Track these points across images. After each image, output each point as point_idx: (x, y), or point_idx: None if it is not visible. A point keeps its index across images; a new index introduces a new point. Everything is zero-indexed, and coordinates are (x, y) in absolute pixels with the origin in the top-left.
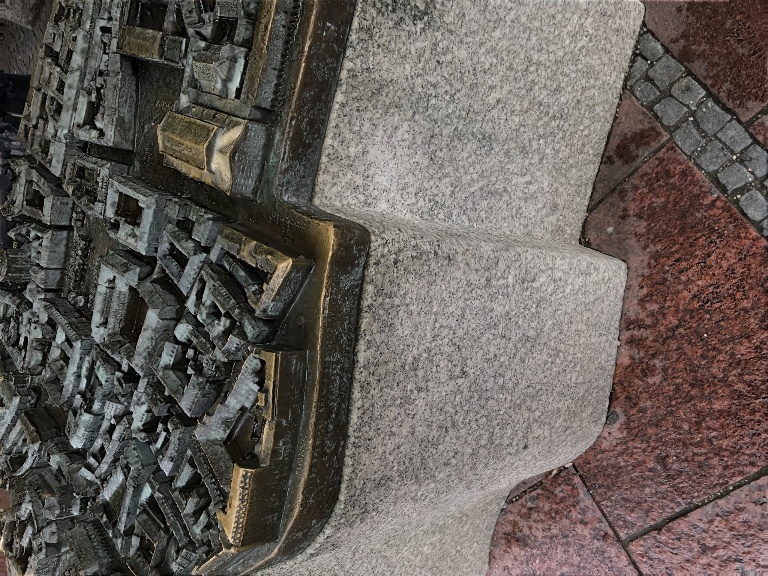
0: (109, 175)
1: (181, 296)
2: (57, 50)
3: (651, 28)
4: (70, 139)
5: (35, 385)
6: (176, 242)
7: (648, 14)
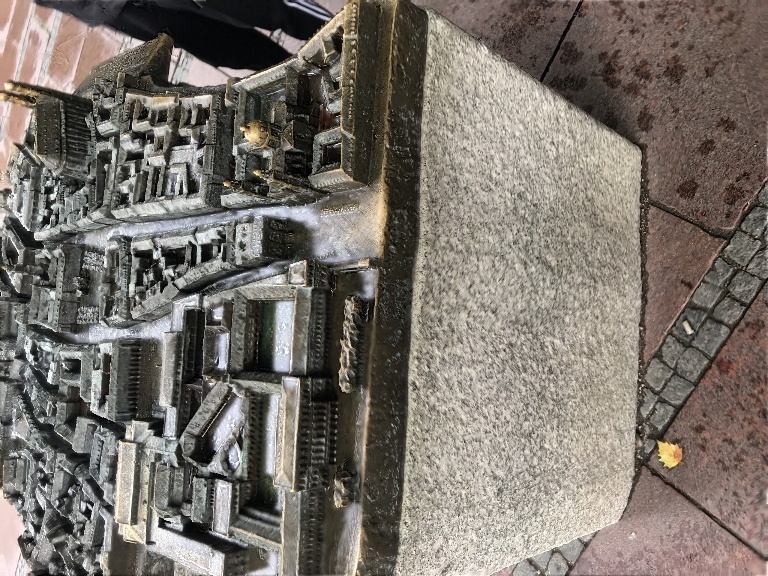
0: (121, 322)
1: None
2: (180, 133)
3: (603, 528)
4: (136, 217)
5: None
6: (101, 461)
7: (615, 523)
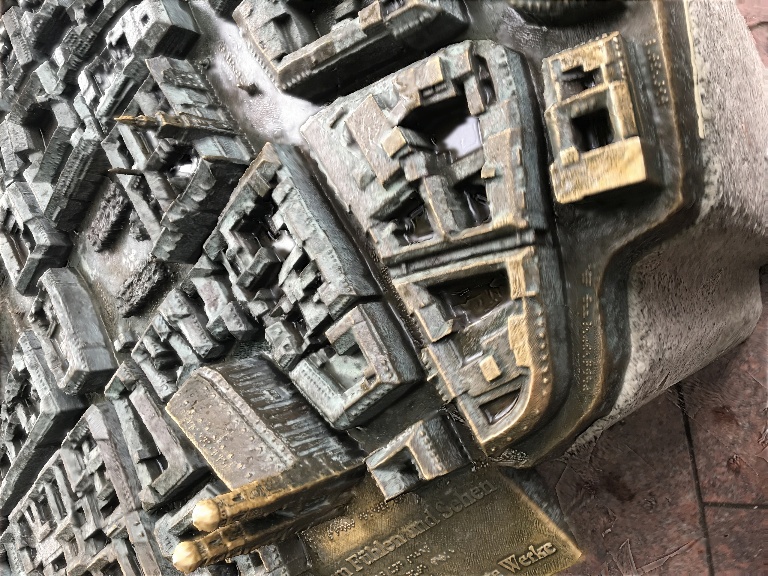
0: None
1: None
2: None
3: None
4: None
5: None
6: None
7: None
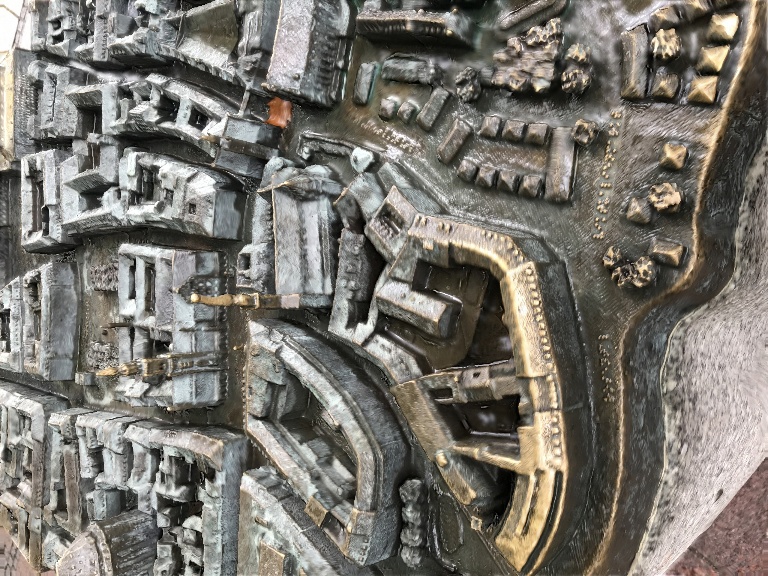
0: None
1: None
2: None
3: None
4: None
5: (179, 355)
6: (41, 100)
7: None
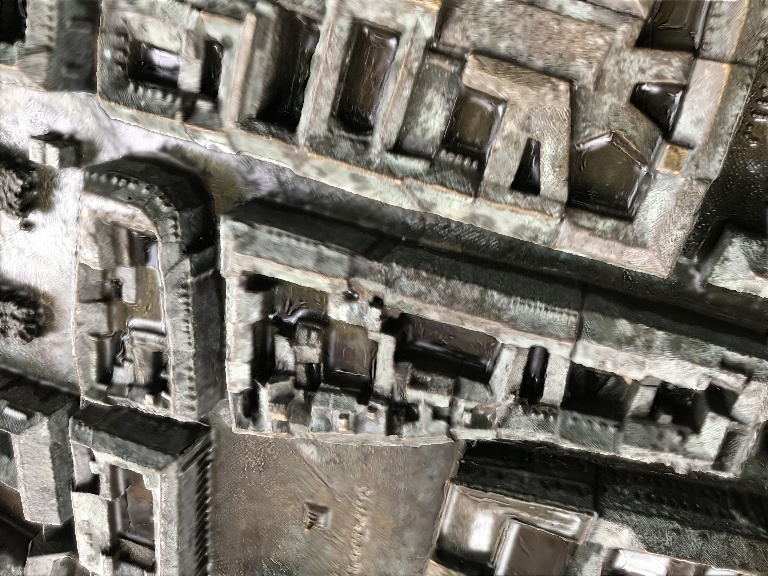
0: None
1: (77, 563)
2: None
3: None
4: None
5: None
6: None
7: None
